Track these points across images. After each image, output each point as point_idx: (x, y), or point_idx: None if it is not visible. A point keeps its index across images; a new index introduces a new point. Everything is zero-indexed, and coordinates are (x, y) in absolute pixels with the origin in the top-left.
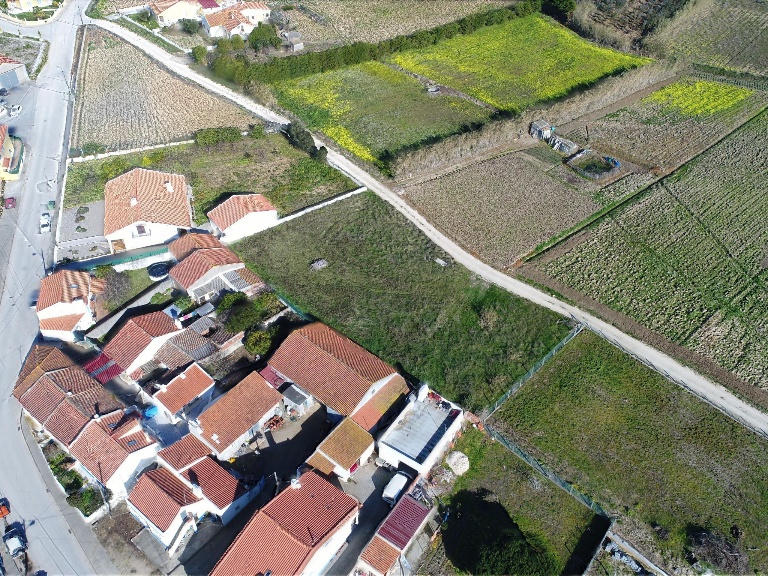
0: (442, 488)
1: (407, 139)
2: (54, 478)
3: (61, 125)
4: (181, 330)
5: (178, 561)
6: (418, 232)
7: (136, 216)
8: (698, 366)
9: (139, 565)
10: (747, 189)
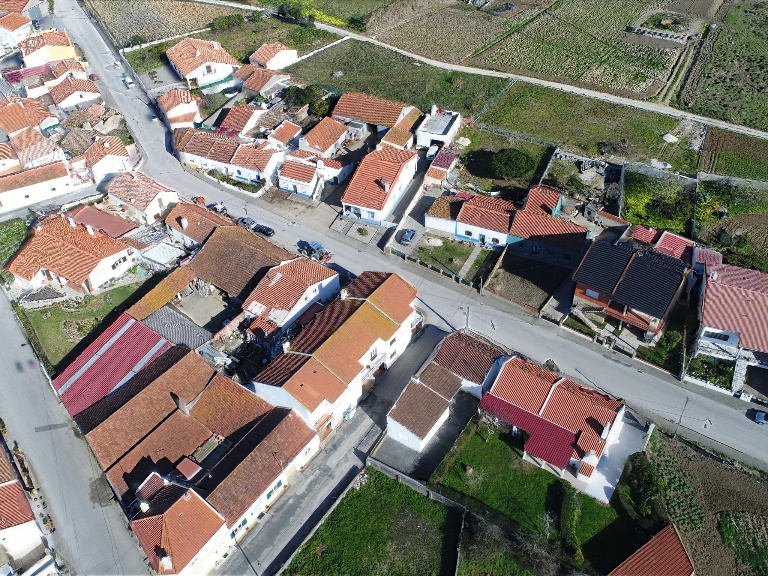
0: (459, 152)
1: (364, 11)
2: (223, 185)
3: (97, 36)
4: (267, 110)
5: (320, 201)
6: (395, 52)
7: (204, 60)
8: (589, 87)
9: (298, 206)
10: (601, 7)
